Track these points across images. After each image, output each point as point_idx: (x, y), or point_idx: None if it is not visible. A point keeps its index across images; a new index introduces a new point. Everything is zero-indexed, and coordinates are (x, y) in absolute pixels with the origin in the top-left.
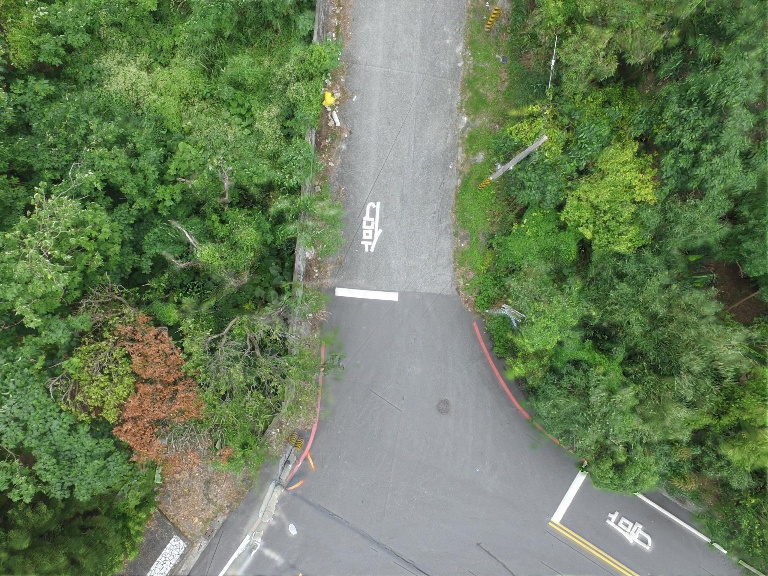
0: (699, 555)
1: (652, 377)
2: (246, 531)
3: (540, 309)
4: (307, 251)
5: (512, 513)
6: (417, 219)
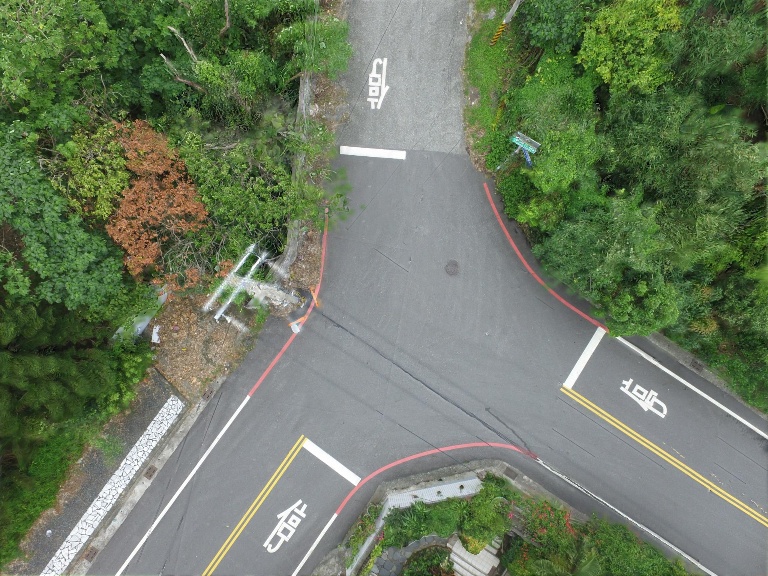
0: (716, 425)
1: (672, 219)
2: (246, 392)
3: (556, 138)
4: (311, 109)
5: (522, 378)
6: (426, 76)
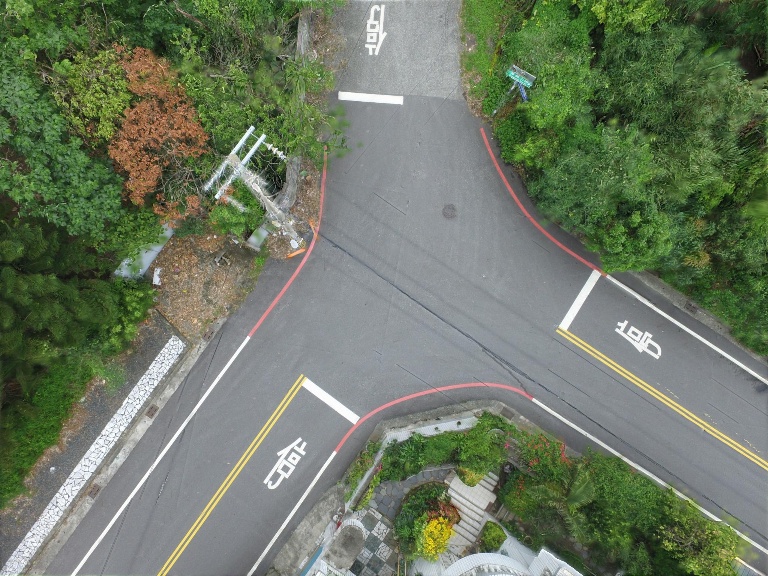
0: (710, 366)
1: (666, 155)
2: (246, 332)
3: (551, 71)
4: (309, 55)
5: (519, 320)
6: (423, 22)
